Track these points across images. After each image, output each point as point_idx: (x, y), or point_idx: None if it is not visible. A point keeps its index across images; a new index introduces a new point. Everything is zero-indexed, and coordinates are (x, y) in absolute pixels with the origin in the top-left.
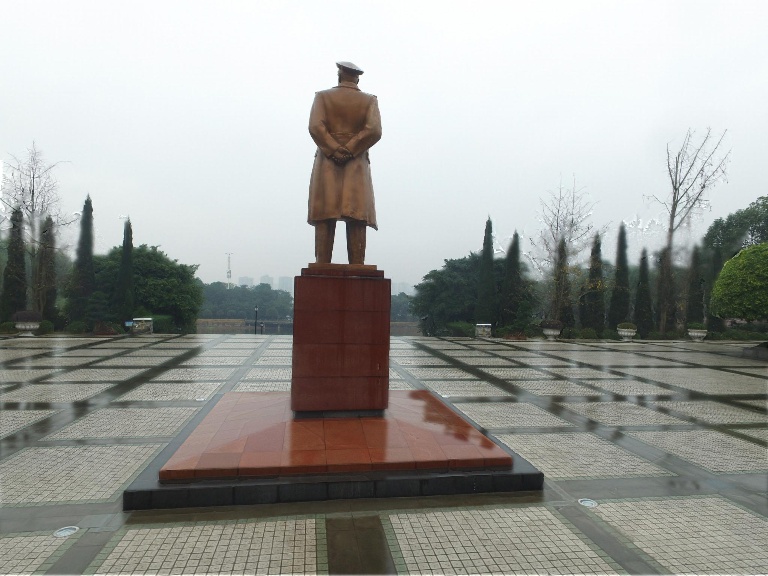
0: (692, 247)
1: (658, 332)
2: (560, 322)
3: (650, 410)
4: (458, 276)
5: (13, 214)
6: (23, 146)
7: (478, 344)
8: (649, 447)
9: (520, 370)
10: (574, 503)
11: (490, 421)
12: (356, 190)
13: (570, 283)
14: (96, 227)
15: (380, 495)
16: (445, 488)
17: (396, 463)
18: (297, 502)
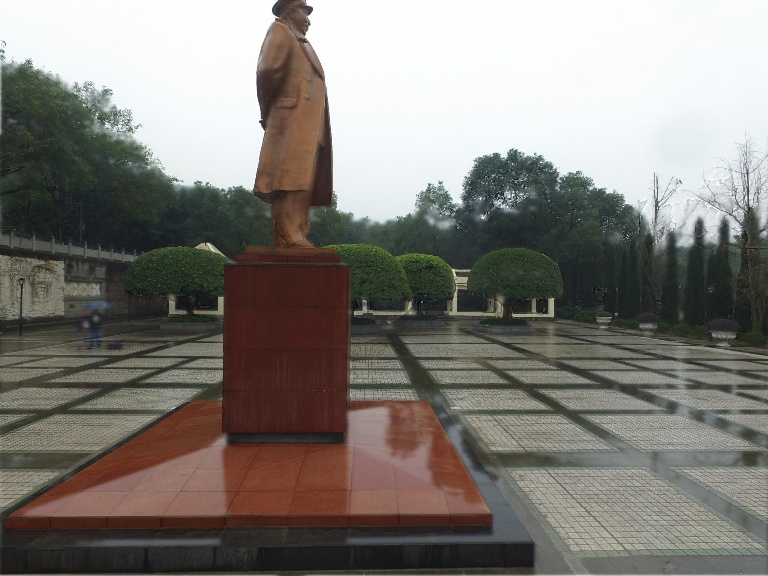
0: None
1: None
2: None
3: None
4: None
5: (745, 217)
6: (733, 144)
7: None
8: None
9: None
10: None
11: None
12: None
13: None
14: None
15: None
16: None
17: None
18: None
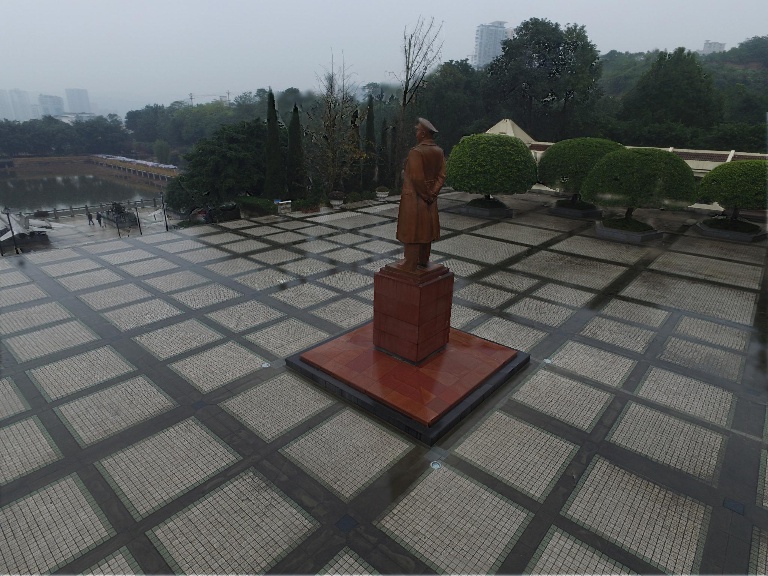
0: None
1: (396, 189)
2: None
3: (491, 288)
4: (239, 148)
5: None
6: None
7: (302, 228)
8: (524, 319)
9: None
10: (545, 363)
11: (451, 323)
12: None
13: (343, 156)
14: None
15: (495, 390)
16: None
17: (491, 373)
18: (476, 408)
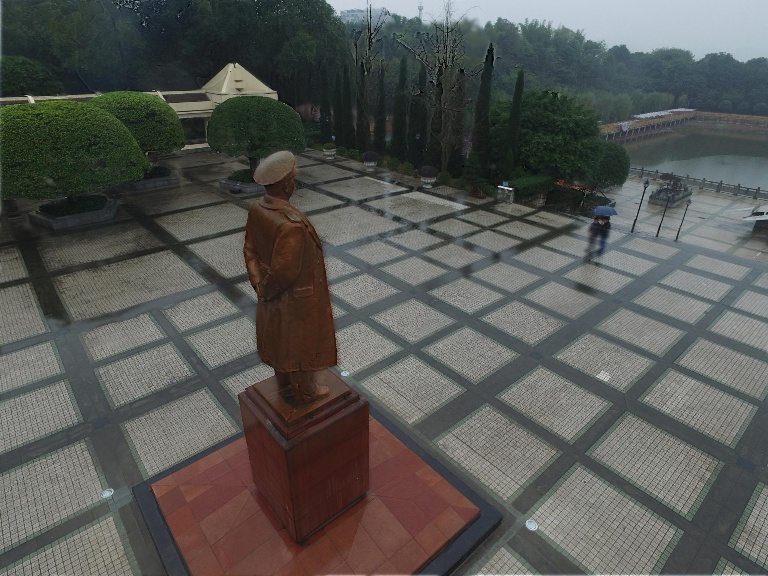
0: None
1: None
2: None
3: None
4: None
5: (440, 67)
6: (439, 1)
7: None
8: None
9: None
10: None
11: None
12: (273, 337)
13: None
14: (502, 73)
15: None
16: None
17: None
18: (165, 571)
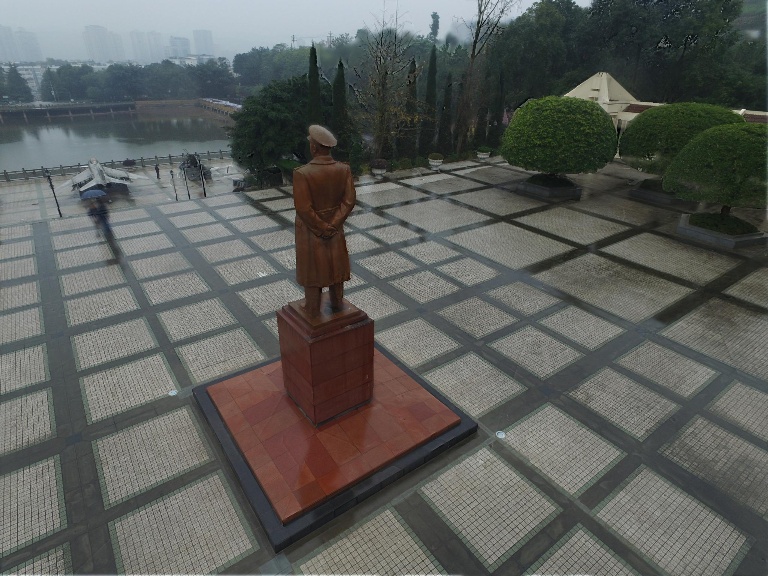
0: (488, 76)
1: (456, 155)
2: (386, 161)
3: (492, 307)
4: (282, 109)
5: None
6: None
7: None
8: (507, 360)
9: (388, 258)
10: (495, 438)
11: (412, 356)
12: (342, 258)
13: None
14: None
15: (406, 473)
16: (435, 454)
17: (407, 450)
18: (367, 499)
